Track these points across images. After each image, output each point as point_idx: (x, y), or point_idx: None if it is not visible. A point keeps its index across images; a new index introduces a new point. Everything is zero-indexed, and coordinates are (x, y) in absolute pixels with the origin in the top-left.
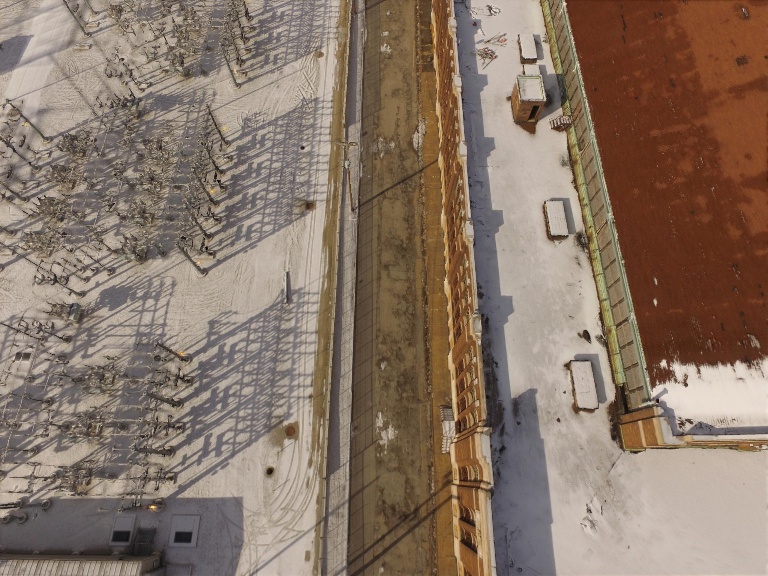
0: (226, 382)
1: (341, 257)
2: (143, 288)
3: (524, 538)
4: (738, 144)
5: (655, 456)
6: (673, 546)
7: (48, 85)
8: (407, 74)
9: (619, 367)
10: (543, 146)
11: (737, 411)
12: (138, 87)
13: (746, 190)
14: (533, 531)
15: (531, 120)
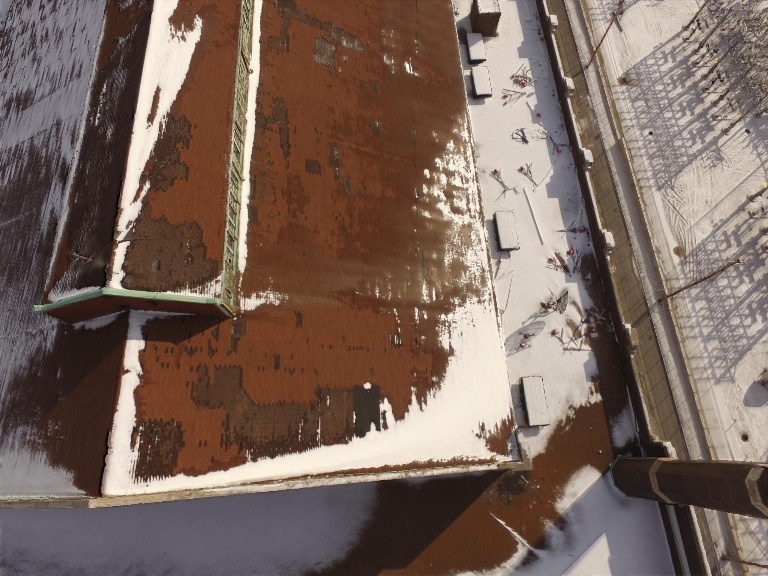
0: None
1: (585, 34)
2: None
3: None
4: None
5: None
6: None
7: None
8: None
9: None
10: None
11: None
12: None
13: None
14: None
15: None
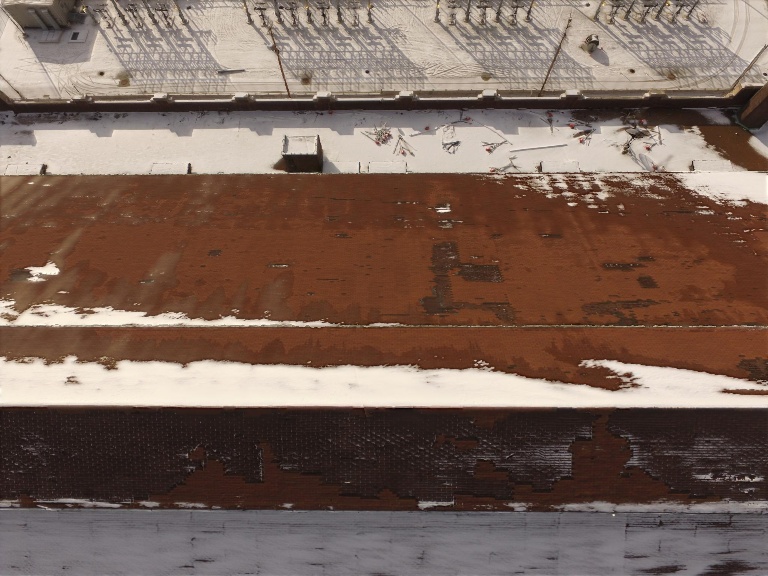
0: (165, 44)
1: None
2: None
3: None
4: (121, 235)
5: None
6: None
7: None
8: None
9: None
10: None
11: None
12: None
13: (72, 231)
14: None
15: None
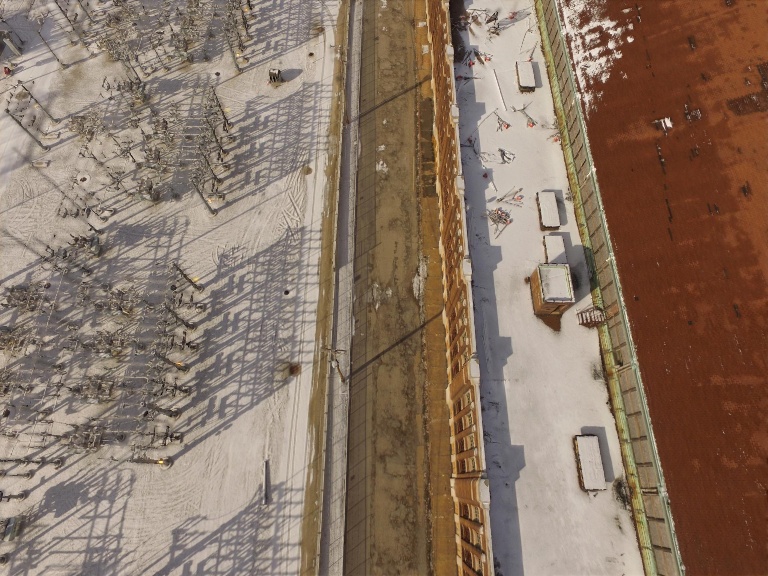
0: None
1: (329, 445)
2: (96, 485)
3: None
4: None
5: None
6: None
7: None
8: (406, 200)
9: None
10: (570, 349)
11: None
12: (100, 217)
13: None
14: None
15: (555, 312)
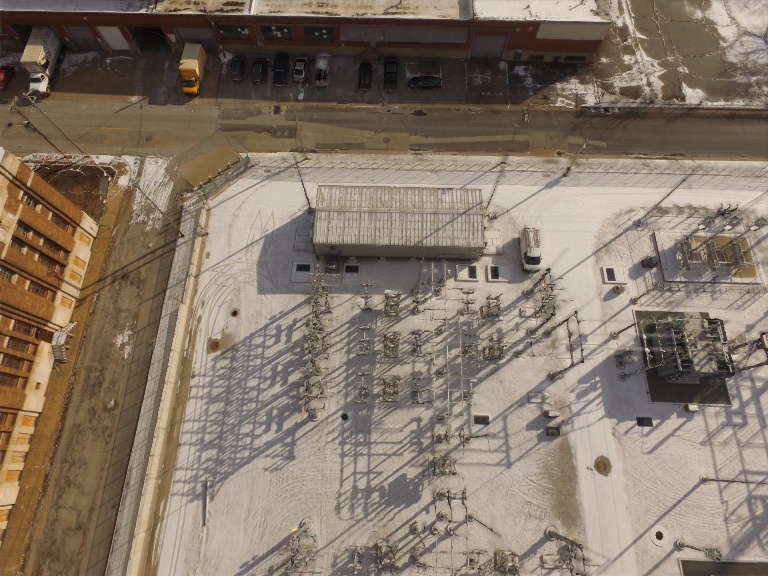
0: (274, 391)
1: (131, 543)
2: (373, 504)
3: None
4: None
5: None
6: None
7: None
8: None
9: None
10: None
11: None
12: None
13: None
14: None
15: None
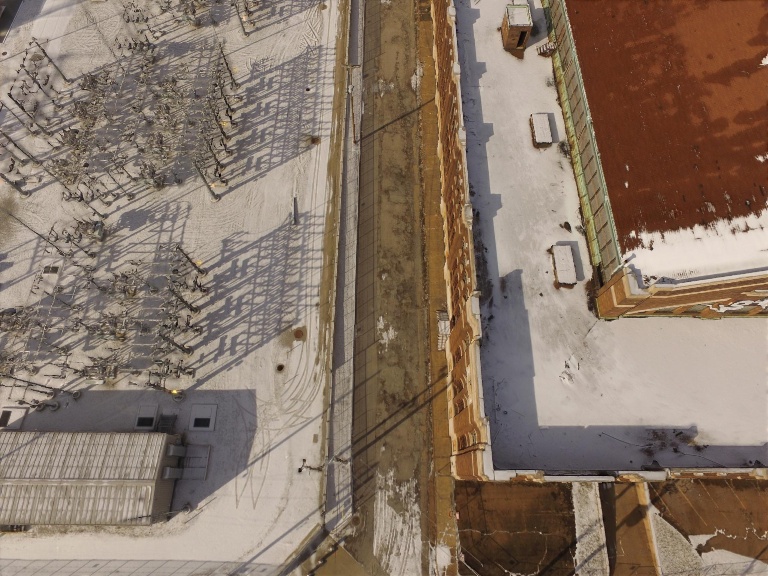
0: (239, 292)
1: (345, 183)
2: (161, 211)
3: (509, 388)
4: (701, 47)
5: (627, 323)
6: (641, 394)
7: (68, 33)
8: (406, 23)
9: (596, 250)
10: (530, 69)
11: (694, 265)
12: (153, 35)
13: (707, 84)
14: (517, 382)
15: (520, 47)
